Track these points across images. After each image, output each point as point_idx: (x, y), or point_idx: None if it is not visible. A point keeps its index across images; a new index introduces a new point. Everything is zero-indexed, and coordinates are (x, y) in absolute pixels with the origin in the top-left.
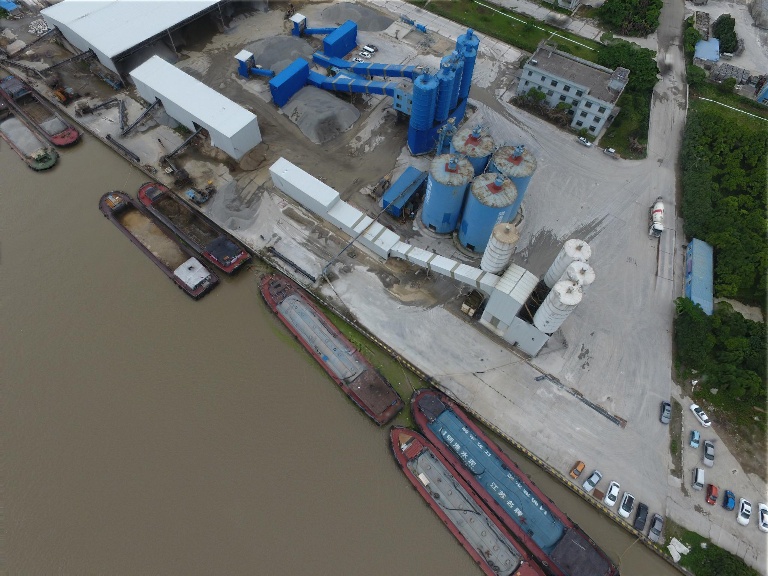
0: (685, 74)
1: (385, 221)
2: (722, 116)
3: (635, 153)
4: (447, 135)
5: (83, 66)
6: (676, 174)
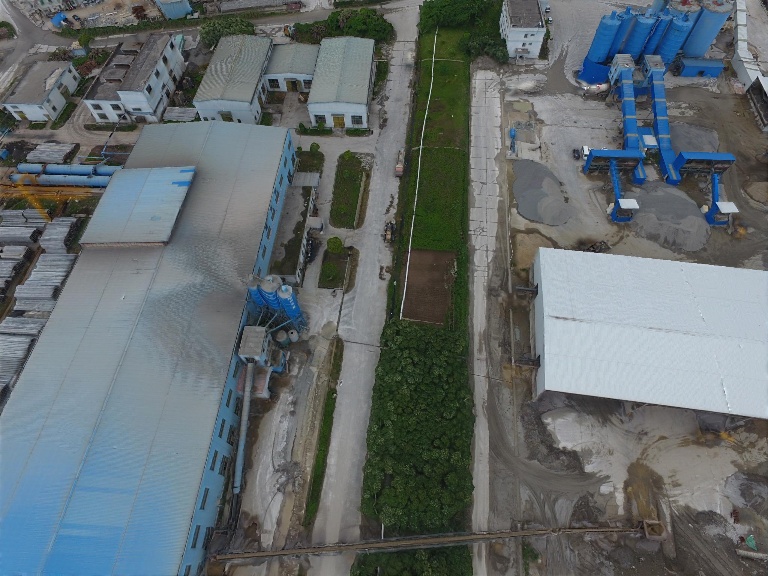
0: None
1: (723, 73)
2: None
3: None
4: None
5: None
6: None
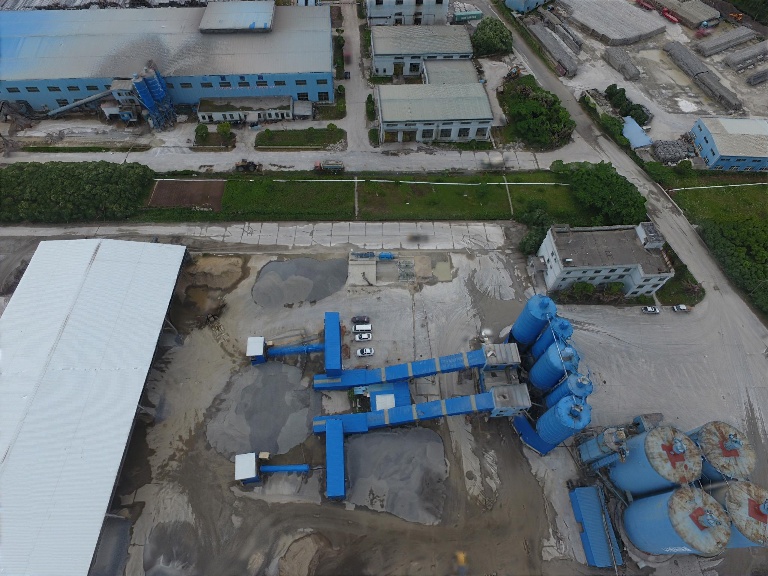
0: (641, 170)
1: None
2: (733, 218)
3: (695, 294)
4: None
5: None
6: (739, 296)
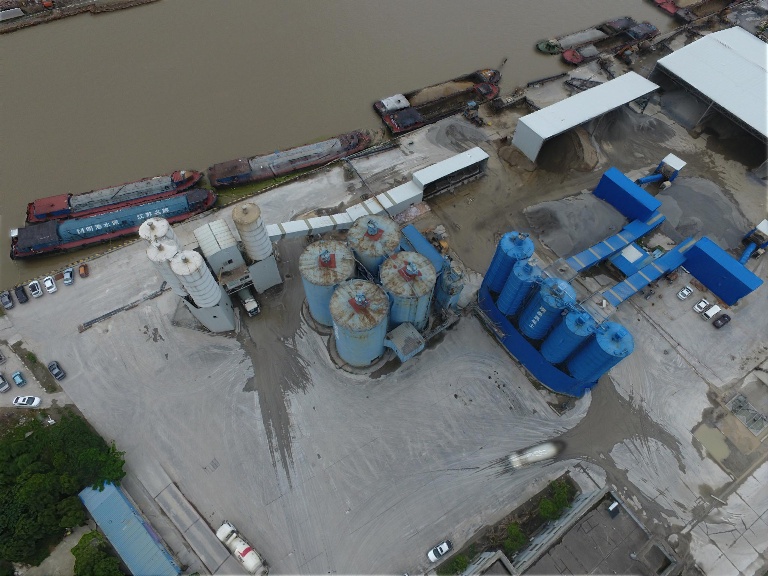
0: None
1: None
2: None
3: None
4: (446, 270)
5: None
6: None
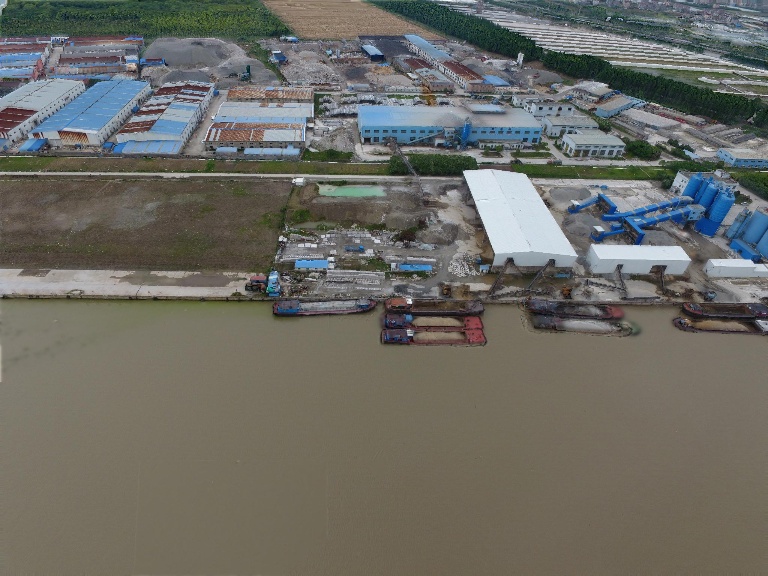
0: None
1: None
2: None
3: (748, 200)
4: None
5: (528, 277)
6: None
